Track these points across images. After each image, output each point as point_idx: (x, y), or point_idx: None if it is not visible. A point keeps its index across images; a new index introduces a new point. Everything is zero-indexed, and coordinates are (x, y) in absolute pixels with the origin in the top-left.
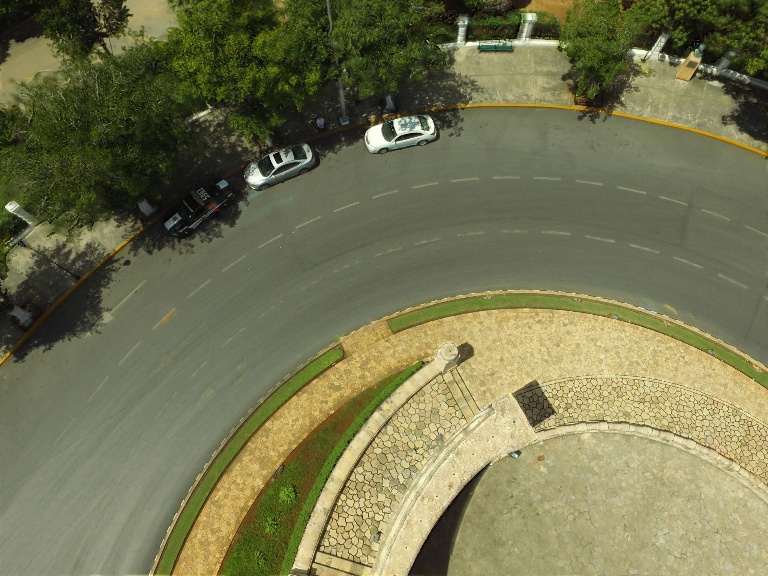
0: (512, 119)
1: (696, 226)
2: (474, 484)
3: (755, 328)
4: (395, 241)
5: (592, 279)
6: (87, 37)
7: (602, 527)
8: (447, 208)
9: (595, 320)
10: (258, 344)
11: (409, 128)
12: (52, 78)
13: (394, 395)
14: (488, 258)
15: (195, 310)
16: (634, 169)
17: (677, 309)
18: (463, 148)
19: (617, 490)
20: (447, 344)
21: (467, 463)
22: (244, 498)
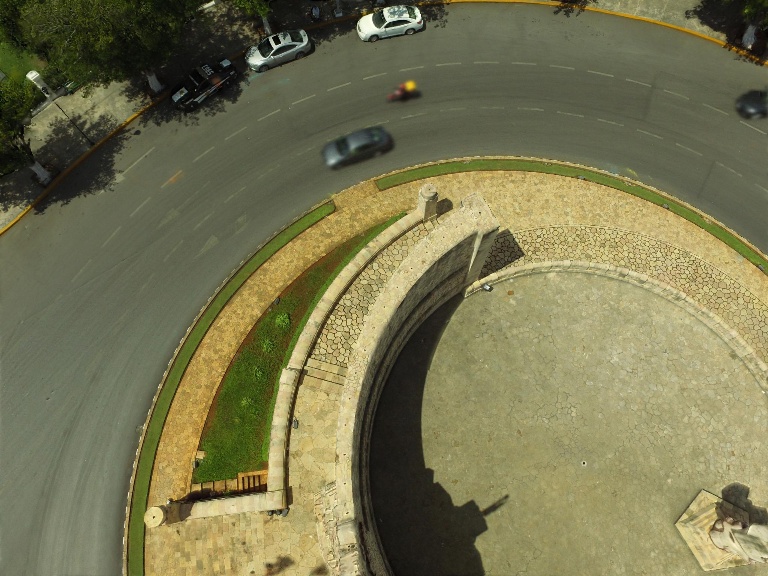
0: (493, 13)
1: (658, 104)
2: (450, 313)
3: (707, 188)
4: (383, 115)
5: (562, 147)
6: None
7: (563, 348)
8: (431, 88)
9: (563, 180)
10: (257, 200)
11: (397, 15)
12: None
13: (379, 235)
14: (468, 130)
15: (200, 172)
16: (603, 56)
17: (638, 172)
18: (447, 37)
19: (578, 318)
20: (427, 184)
21: (438, 244)
22: (244, 325)
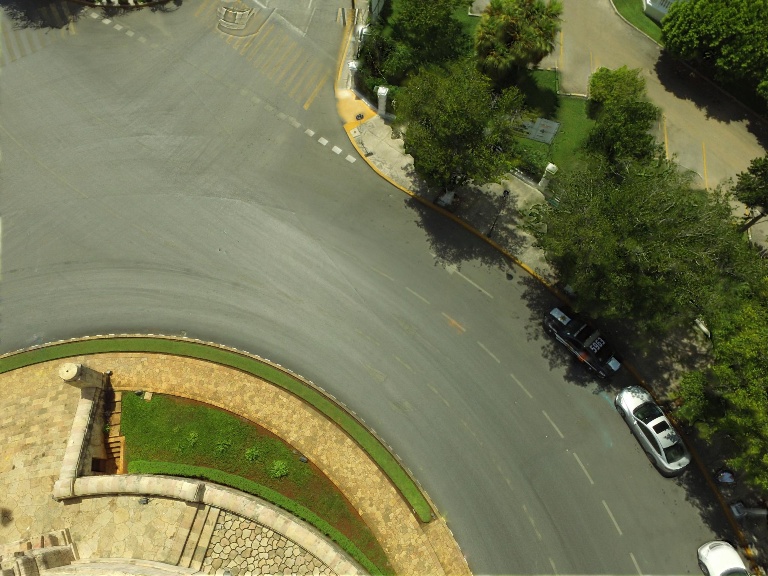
0: None
1: None
2: None
3: None
4: None
5: None
6: (766, 201)
7: None
8: None
9: None
10: (432, 422)
11: None
12: (695, 188)
13: None
14: None
15: (465, 351)
16: None
17: None
18: None
19: None
20: None
21: None
22: (279, 424)
